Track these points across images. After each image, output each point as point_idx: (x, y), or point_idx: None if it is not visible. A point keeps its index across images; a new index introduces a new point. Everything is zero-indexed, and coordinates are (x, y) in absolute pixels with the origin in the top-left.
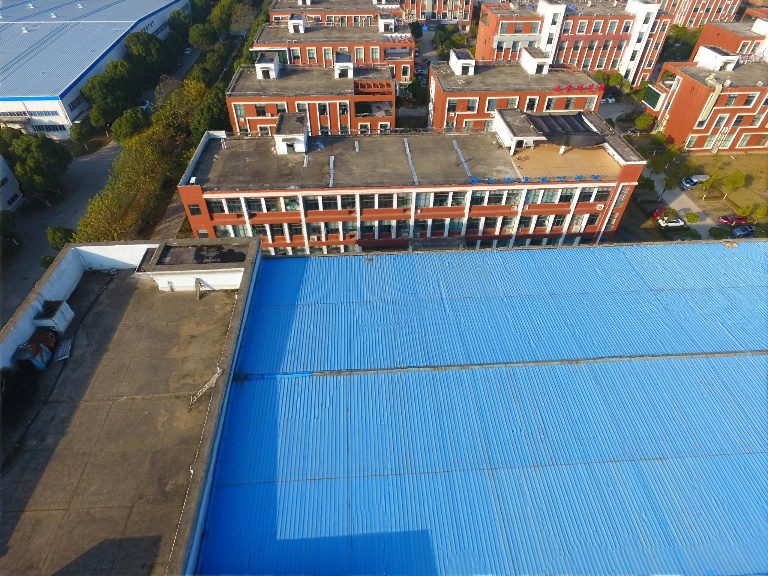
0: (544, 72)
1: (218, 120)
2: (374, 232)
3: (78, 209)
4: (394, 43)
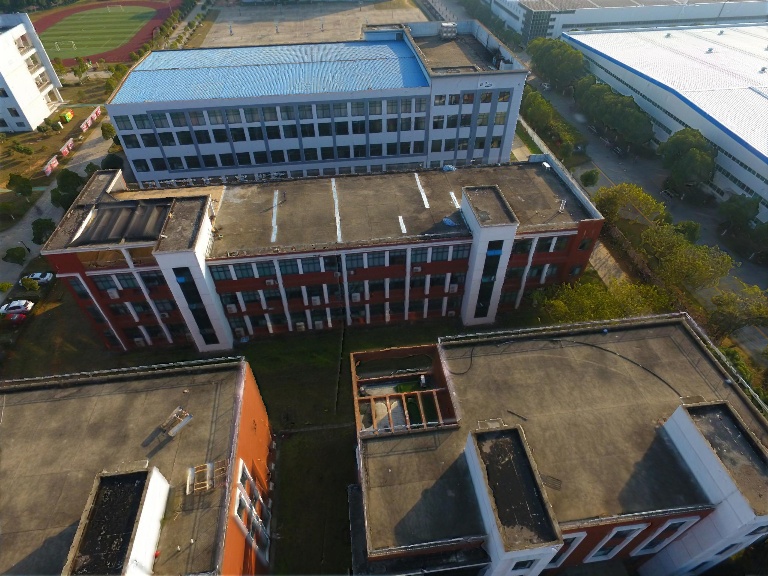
0: None
1: None
2: None
3: None
4: None
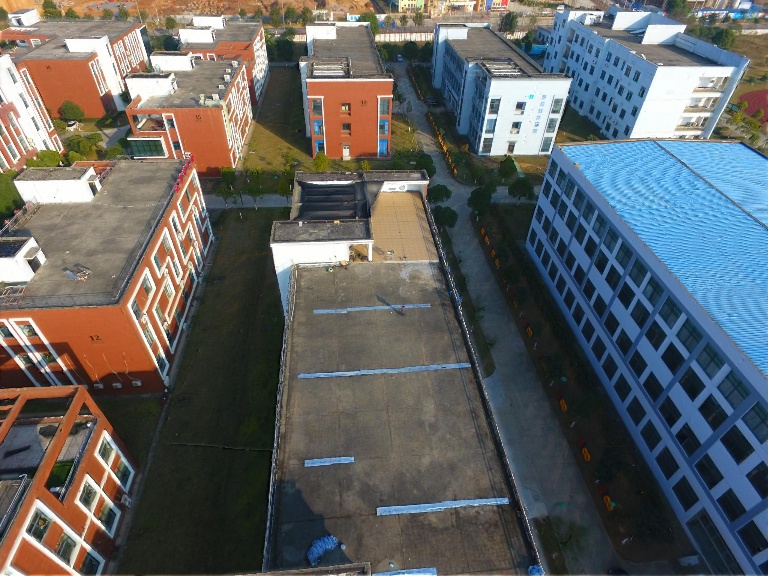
0: (98, 188)
1: None
2: None
3: None
4: None
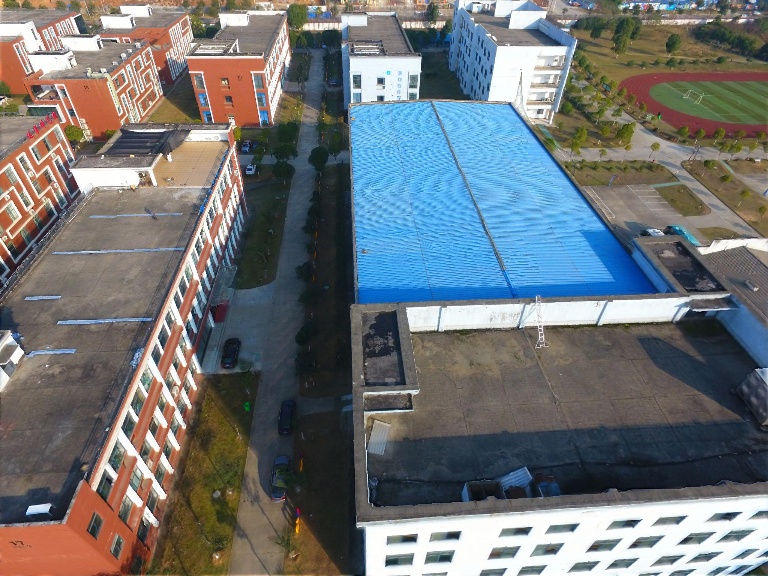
0: None
1: None
2: (191, 328)
3: None
4: None
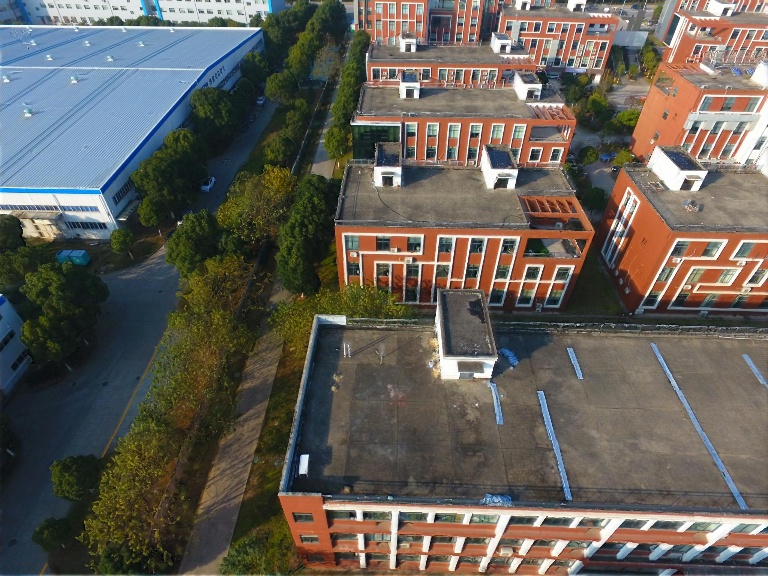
0: None
1: (313, 241)
2: (619, 548)
3: (109, 379)
4: (547, 120)
